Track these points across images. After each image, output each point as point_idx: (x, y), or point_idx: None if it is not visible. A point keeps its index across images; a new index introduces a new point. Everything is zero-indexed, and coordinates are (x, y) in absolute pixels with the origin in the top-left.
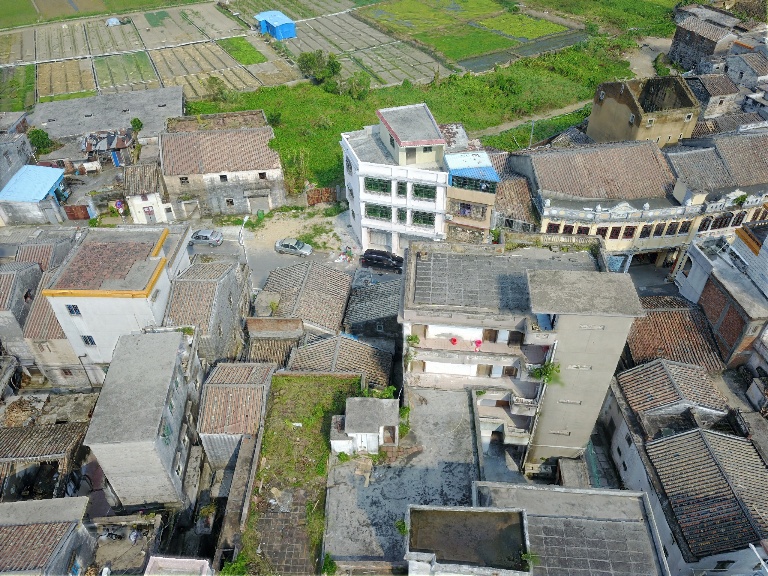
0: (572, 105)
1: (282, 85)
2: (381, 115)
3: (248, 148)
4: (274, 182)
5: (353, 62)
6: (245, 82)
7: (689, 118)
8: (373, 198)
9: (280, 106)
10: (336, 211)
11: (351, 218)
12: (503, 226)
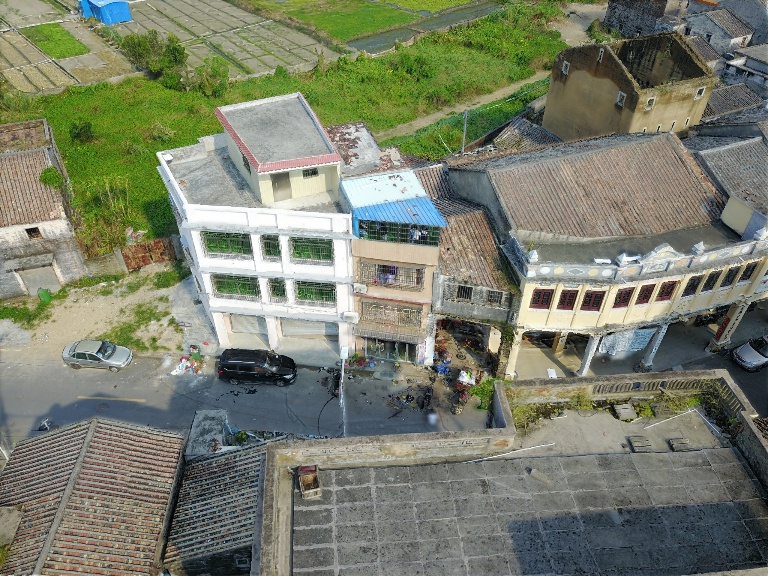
0: (503, 88)
1: (102, 82)
2: (223, 117)
3: (3, 187)
4: (58, 241)
5: (209, 49)
6: (54, 82)
7: (700, 94)
8: (223, 265)
9: (97, 112)
10: (175, 277)
11: (198, 290)
12: (455, 297)
